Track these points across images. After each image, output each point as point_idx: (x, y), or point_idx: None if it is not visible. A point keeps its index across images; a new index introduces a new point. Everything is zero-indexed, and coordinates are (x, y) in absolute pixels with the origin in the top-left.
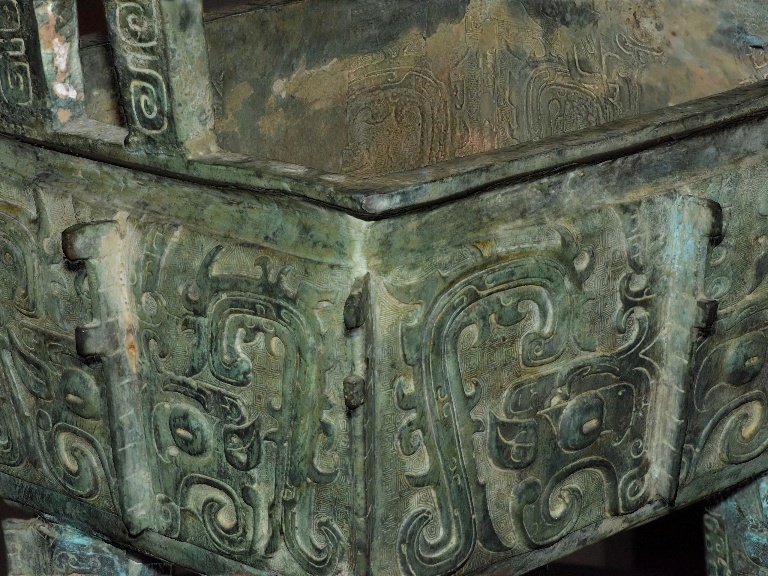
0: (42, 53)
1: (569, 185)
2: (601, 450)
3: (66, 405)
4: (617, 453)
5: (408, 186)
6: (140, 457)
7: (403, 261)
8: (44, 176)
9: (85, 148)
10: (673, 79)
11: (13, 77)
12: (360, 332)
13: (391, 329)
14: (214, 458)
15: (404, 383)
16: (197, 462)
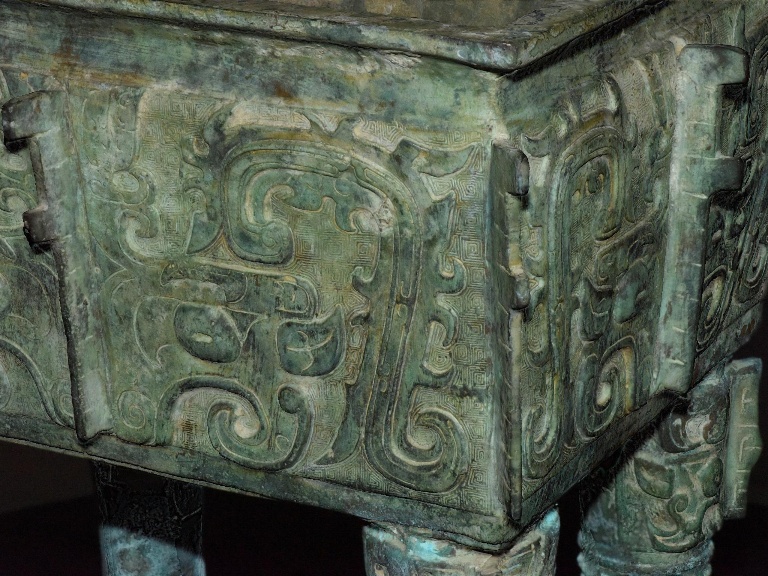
0: None
1: None
2: None
3: None
4: None
5: None
6: None
7: None
8: (602, 60)
9: None
10: None
11: None
12: None
13: None
14: None
15: None
16: None
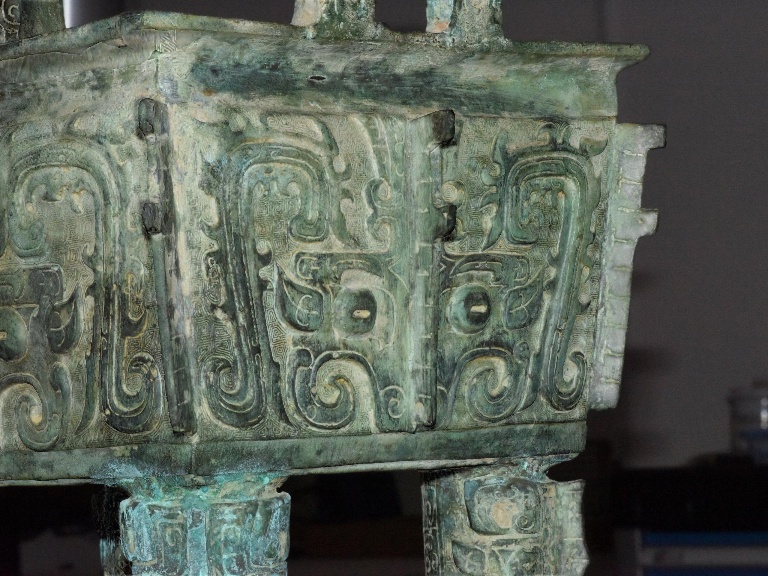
0: None
1: None
2: None
3: None
4: None
5: None
6: None
7: None
8: None
9: None
10: None
11: None
12: None
13: None
14: None
15: None
16: None
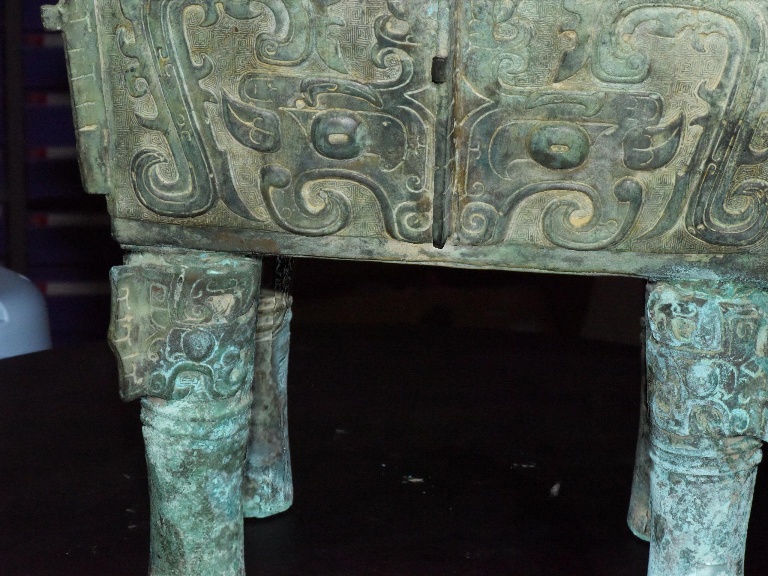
0: None
1: None
2: (366, 169)
3: None
4: (388, 179)
5: None
6: None
7: None
8: None
9: None
10: None
11: None
12: None
13: None
14: None
15: (126, 33)
16: None
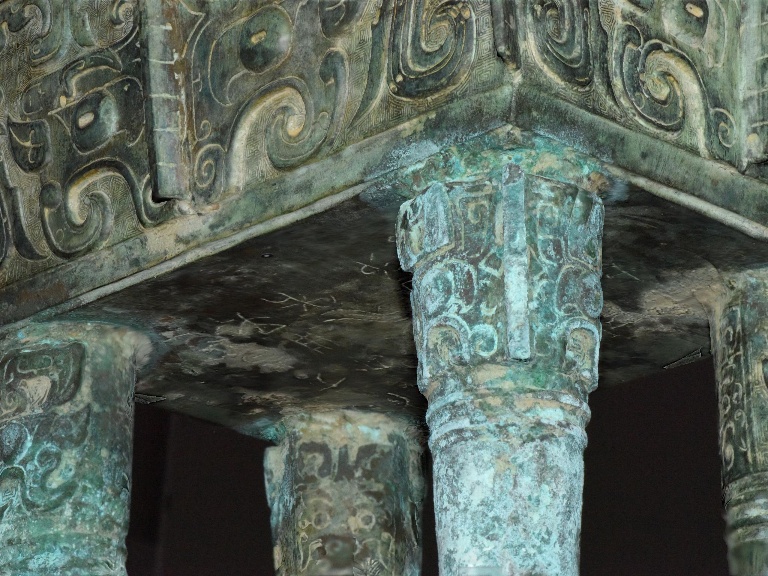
0: None
1: None
2: None
3: None
4: (134, 154)
5: None
6: None
7: None
8: None
9: None
10: None
11: None
12: None
13: None
14: None
15: None
16: None
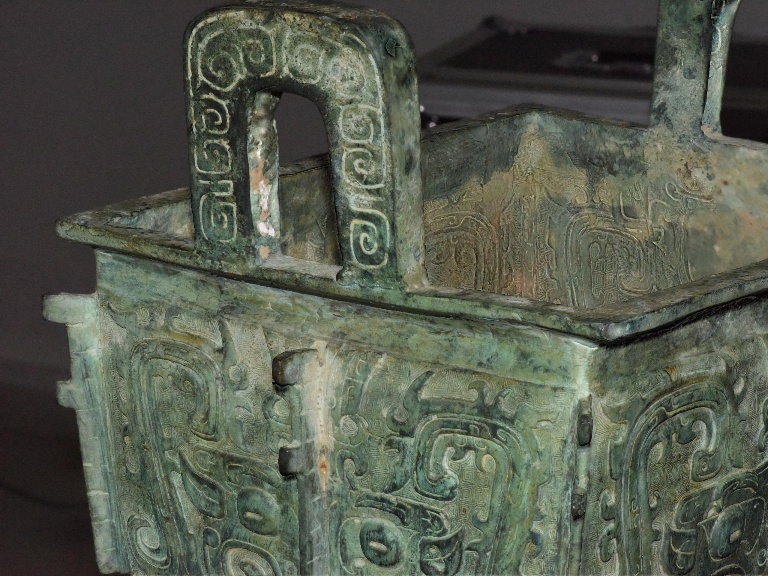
0: (250, 194)
1: (730, 317)
2: (738, 558)
3: (243, 522)
4: (748, 561)
5: (635, 316)
6: (323, 569)
7: (615, 384)
8: (229, 308)
9: (291, 282)
10: (720, 224)
11: (217, 216)
12: (587, 448)
13: (602, 446)
14: (406, 568)
15: (607, 496)
16: (386, 573)
